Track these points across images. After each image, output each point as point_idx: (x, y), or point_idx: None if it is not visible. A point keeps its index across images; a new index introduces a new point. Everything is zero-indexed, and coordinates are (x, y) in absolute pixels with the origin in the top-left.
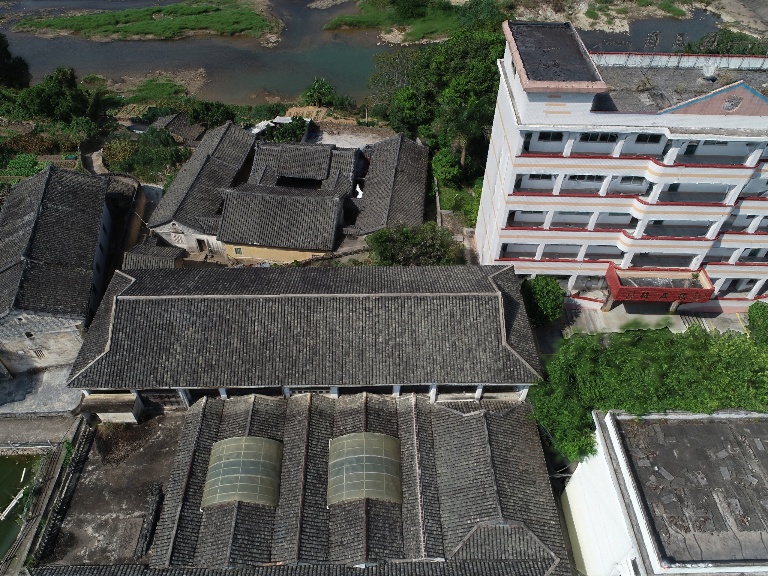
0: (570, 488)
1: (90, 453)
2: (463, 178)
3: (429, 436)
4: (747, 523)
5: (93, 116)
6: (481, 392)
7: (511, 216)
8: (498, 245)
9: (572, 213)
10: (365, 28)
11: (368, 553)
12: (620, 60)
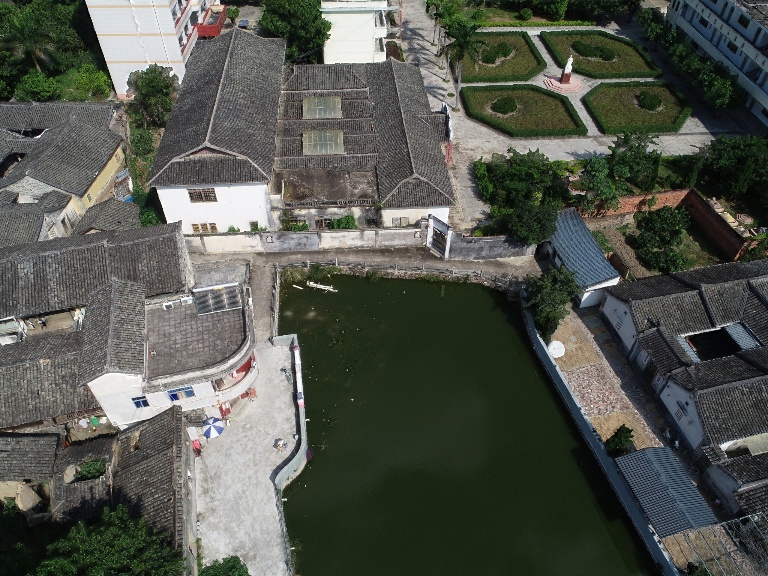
0: None
1: None
2: None
3: None
4: None
5: None
6: None
7: None
8: (178, 42)
9: None
10: None
11: None
12: None
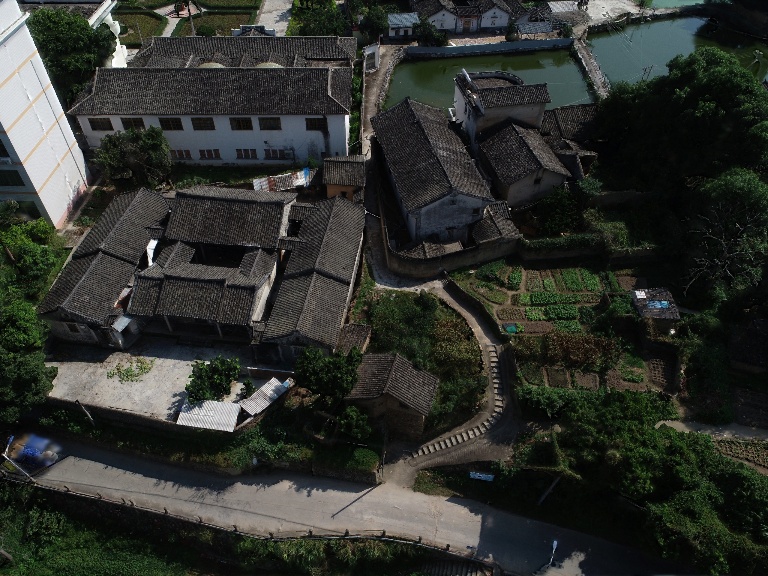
0: None
1: None
2: None
3: None
4: (66, 6)
5: None
6: None
7: None
8: None
9: None
10: None
11: None
12: None
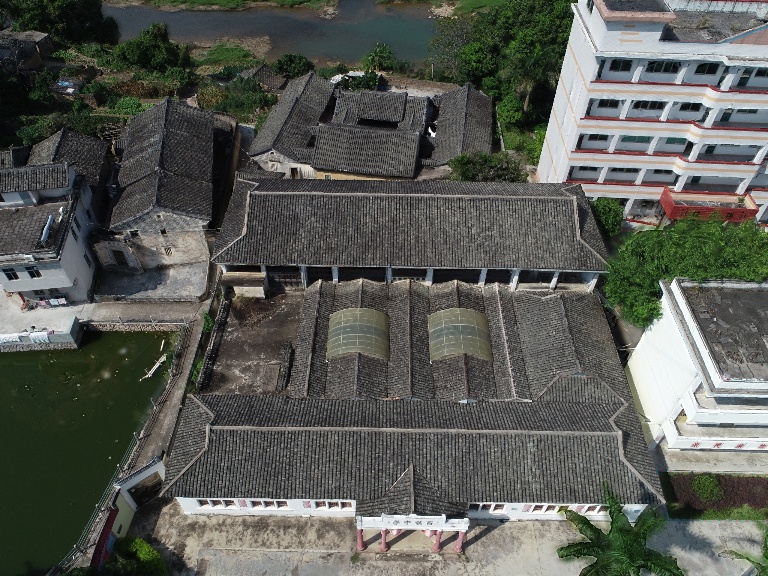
0: (633, 360)
1: (228, 319)
2: (525, 124)
3: (512, 315)
4: None
5: (183, 68)
6: (556, 281)
7: (579, 142)
8: (567, 167)
9: (633, 141)
10: (416, 3)
11: (469, 392)
12: (681, 5)
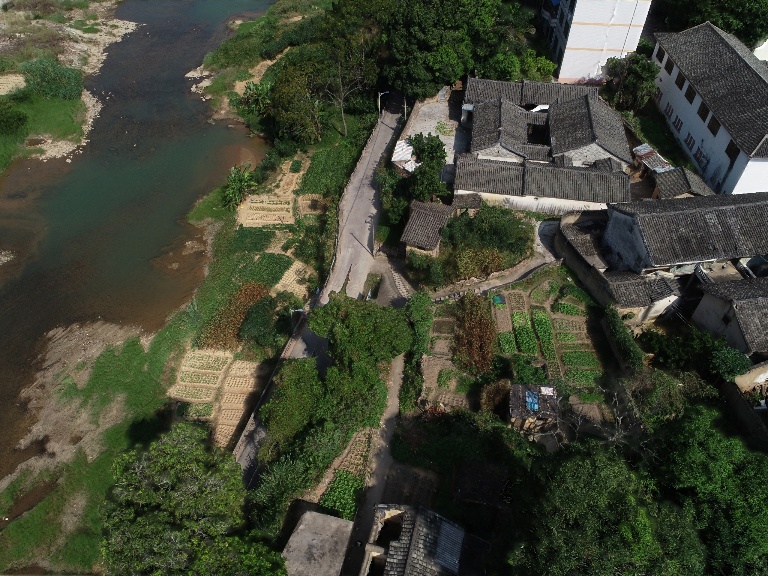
0: None
1: None
2: None
3: None
4: None
5: None
6: None
7: None
8: None
9: None
10: (7, 169)
11: None
12: None
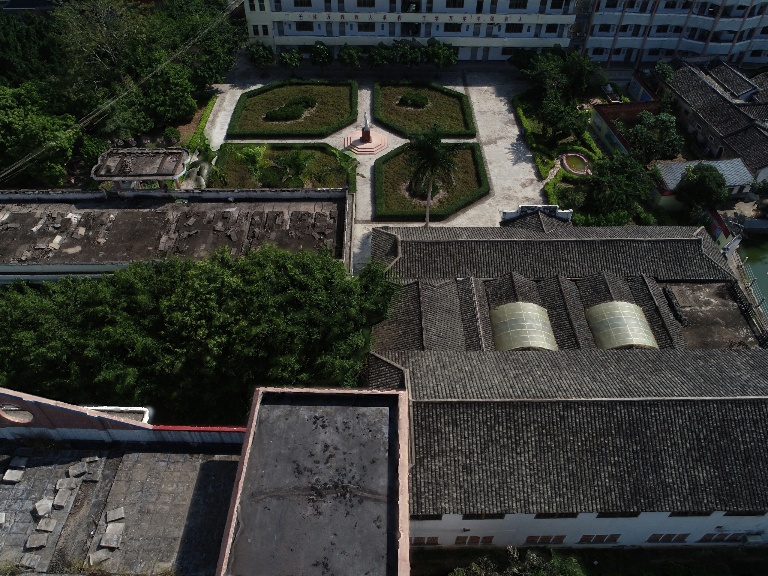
0: None
1: None
2: None
3: None
4: None
5: None
6: None
7: None
8: None
9: None
10: None
11: None
12: None
